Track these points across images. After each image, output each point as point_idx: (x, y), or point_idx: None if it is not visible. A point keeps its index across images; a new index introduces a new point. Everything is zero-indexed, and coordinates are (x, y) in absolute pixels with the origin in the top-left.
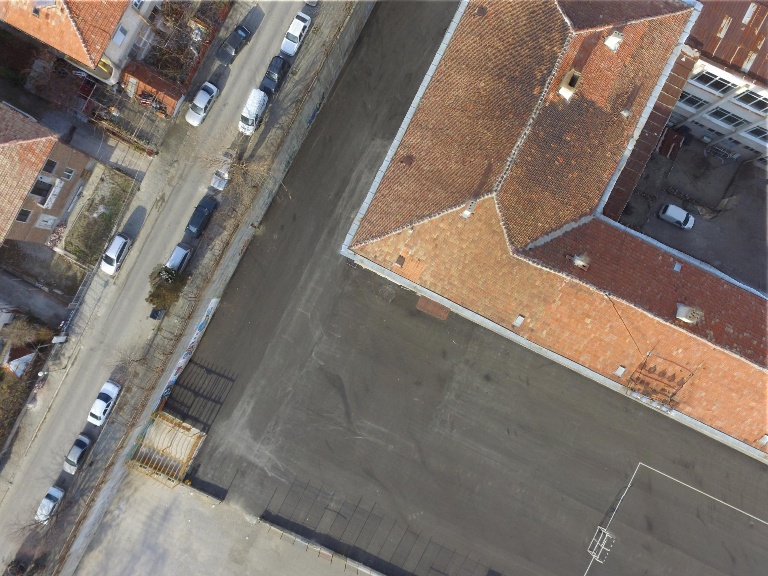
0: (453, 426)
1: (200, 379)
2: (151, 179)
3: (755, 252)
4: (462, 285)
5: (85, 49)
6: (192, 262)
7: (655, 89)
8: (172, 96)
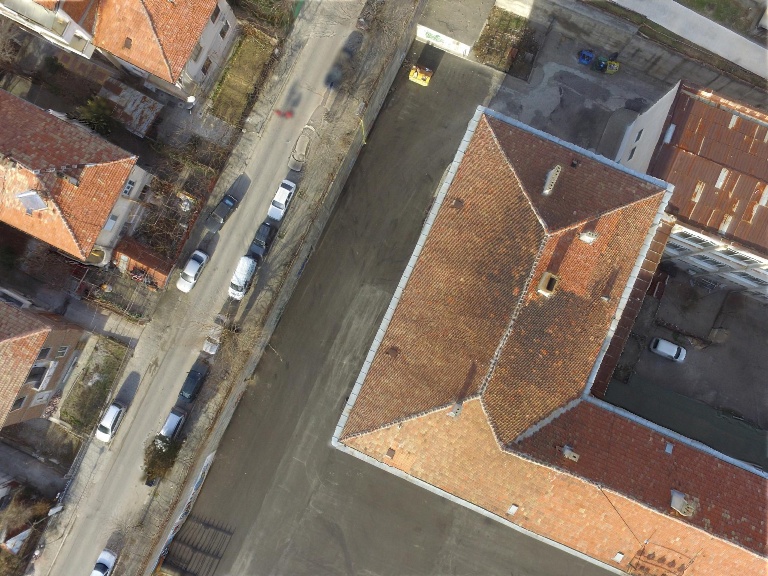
0: (456, 572)
1: (198, 534)
2: (144, 345)
3: (750, 380)
4: (453, 476)
5: (77, 244)
6: (186, 426)
7: (633, 269)
8: (163, 272)
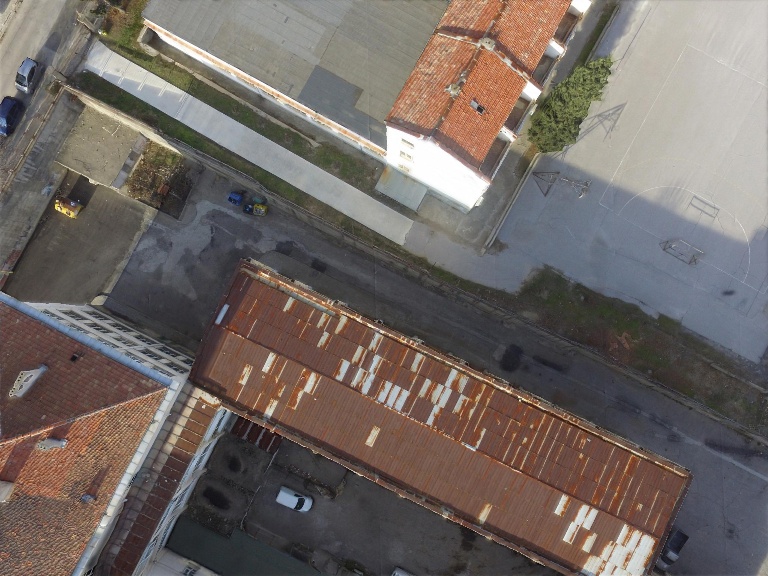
0: None
1: None
2: None
3: (377, 532)
4: None
5: None
6: None
7: (130, 466)
8: None
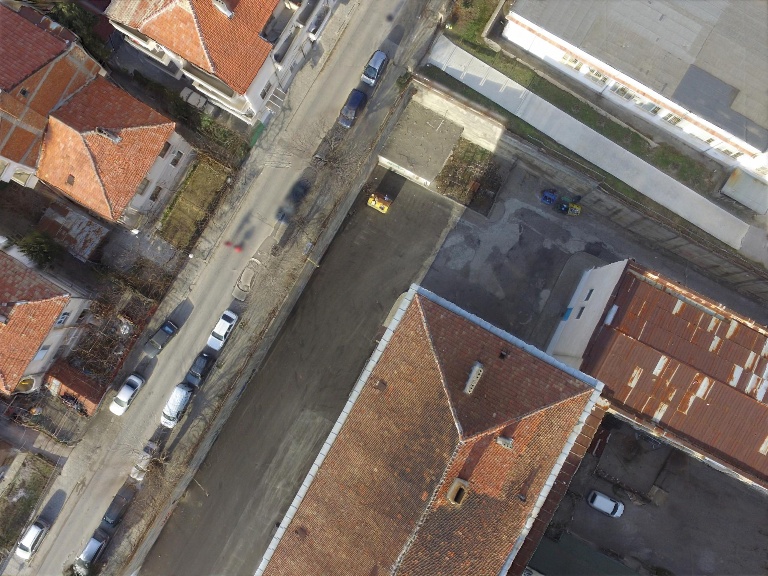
0: None
1: None
2: (73, 465)
3: (687, 541)
4: None
5: (2, 379)
6: (108, 549)
7: (555, 467)
8: (93, 400)
